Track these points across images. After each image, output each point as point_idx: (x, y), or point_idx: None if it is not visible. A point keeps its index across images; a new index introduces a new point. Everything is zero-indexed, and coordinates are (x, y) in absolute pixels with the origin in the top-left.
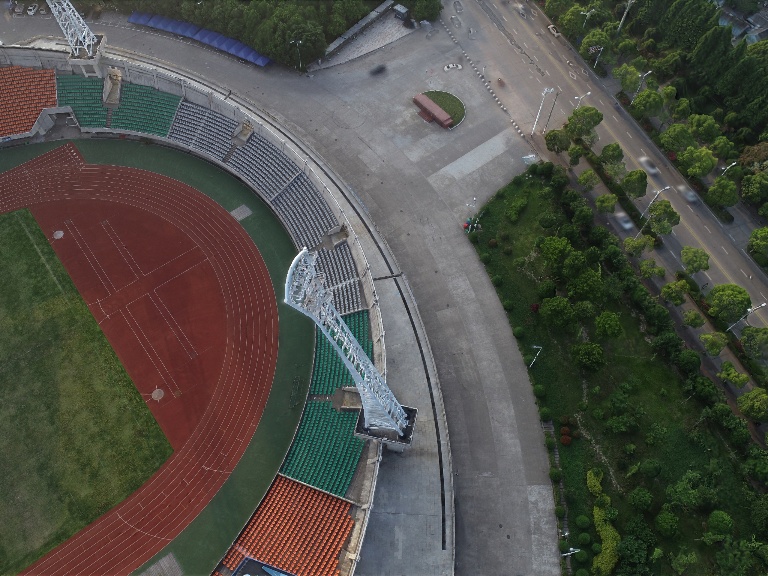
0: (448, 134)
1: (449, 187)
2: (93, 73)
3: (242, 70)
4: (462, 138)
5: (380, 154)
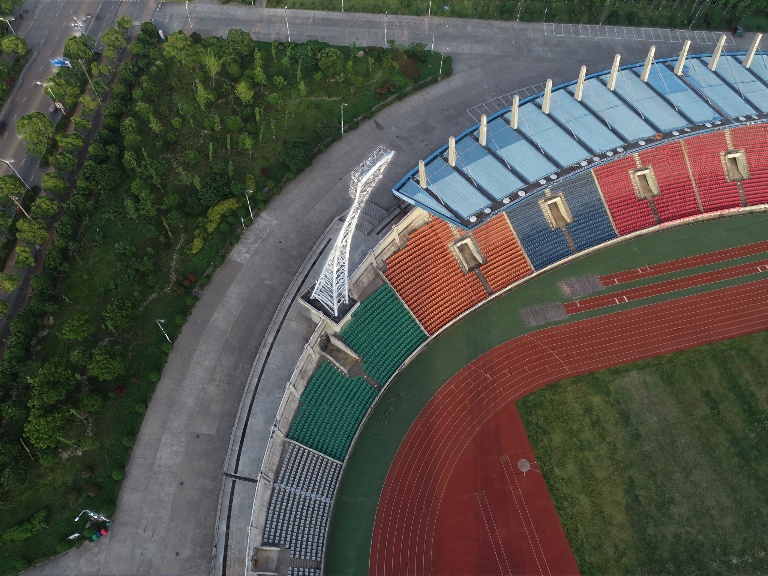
0: None
1: None
2: None
3: None
4: None
5: None
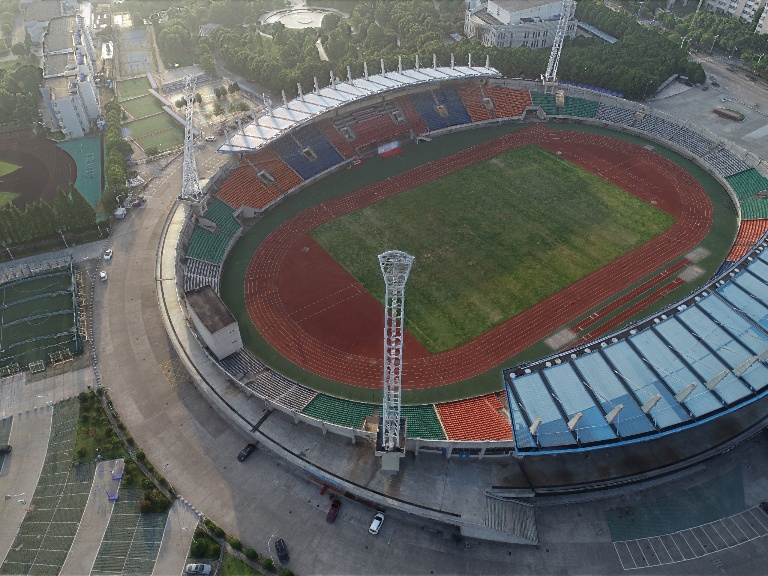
0: (740, 123)
1: (755, 141)
2: (550, 92)
3: None
4: (749, 125)
5: (708, 130)
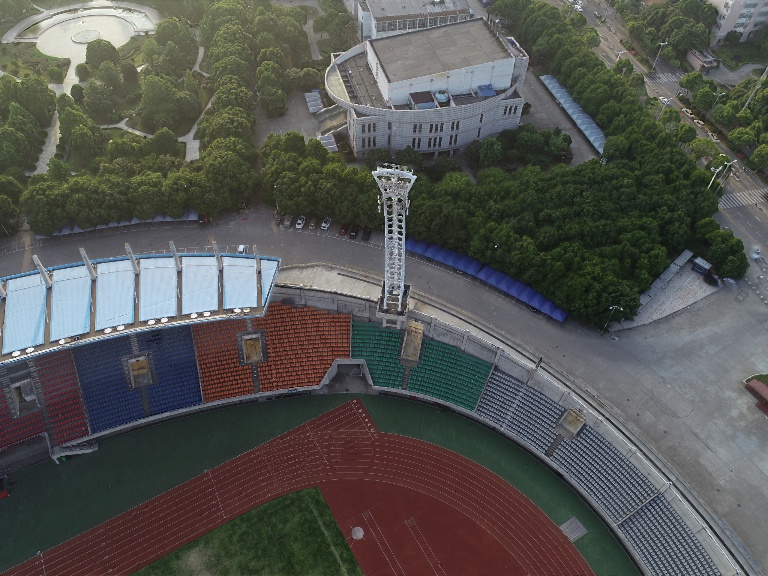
0: None
1: None
2: (393, 324)
3: (534, 321)
4: None
5: (725, 460)
